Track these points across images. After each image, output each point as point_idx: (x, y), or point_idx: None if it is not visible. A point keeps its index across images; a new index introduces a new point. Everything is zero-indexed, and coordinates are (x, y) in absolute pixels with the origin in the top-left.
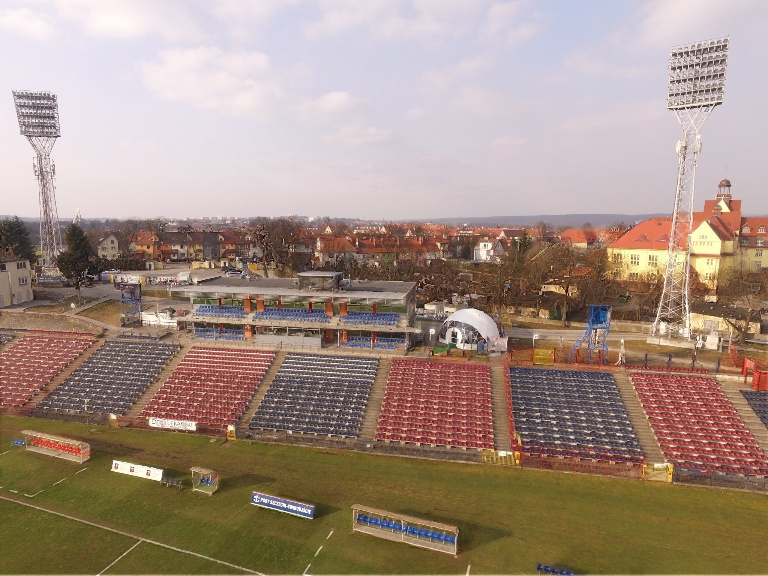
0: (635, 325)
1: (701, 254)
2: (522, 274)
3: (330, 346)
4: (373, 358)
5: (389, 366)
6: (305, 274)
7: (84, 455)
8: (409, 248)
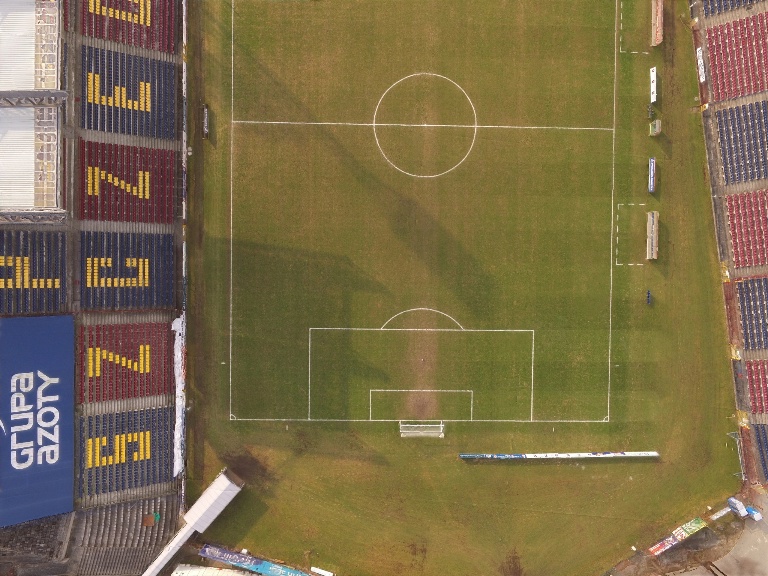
0: None
1: None
2: None
3: None
4: None
5: None
6: None
7: (656, 43)
8: None
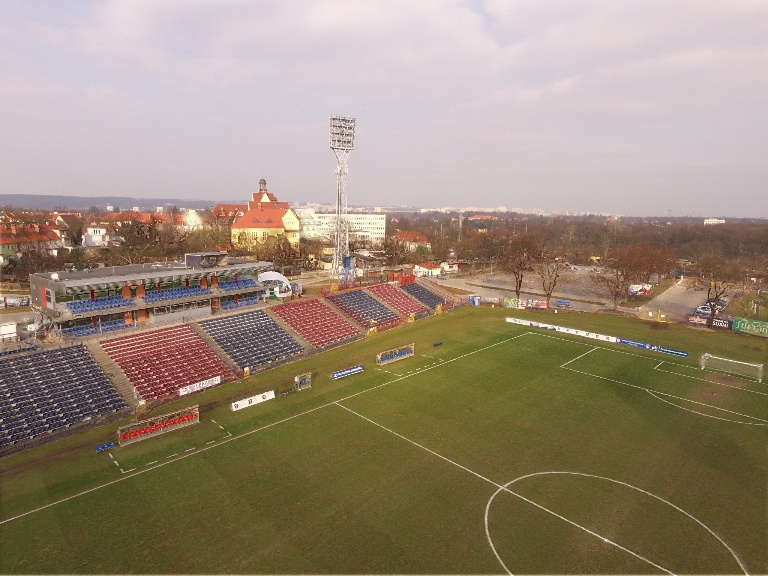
0: (316, 273)
1: (290, 230)
2: (179, 254)
3: (215, 312)
4: (259, 310)
5: (272, 312)
6: (207, 254)
7: None
8: (28, 237)
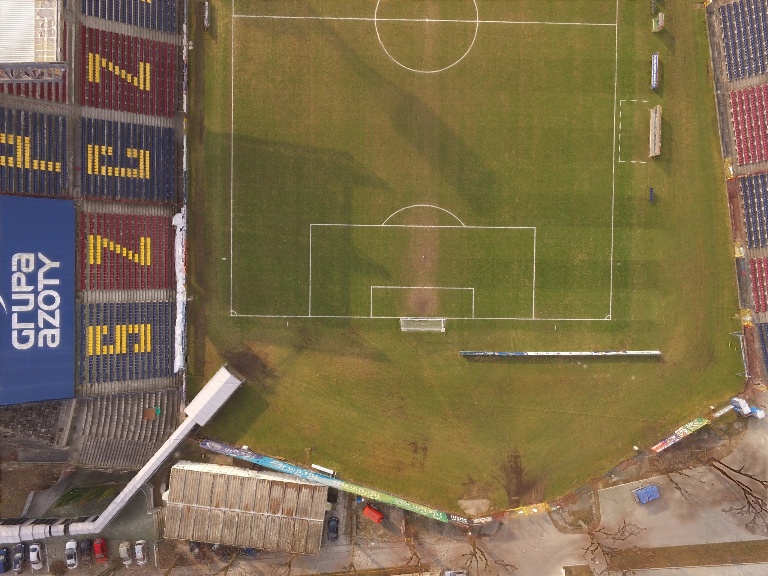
0: None
1: None
2: None
3: None
4: None
5: None
6: None
7: None
8: None
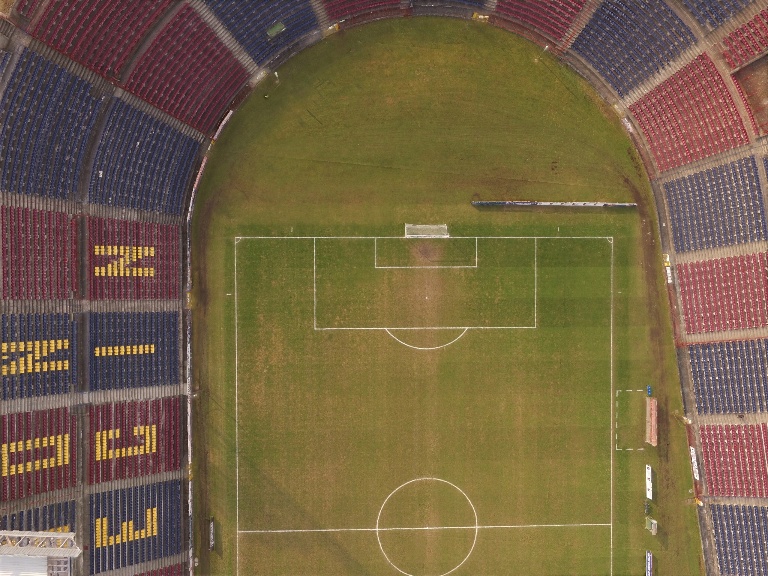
0: None
1: None
2: None
3: None
4: None
5: None
6: None
7: None
8: None
